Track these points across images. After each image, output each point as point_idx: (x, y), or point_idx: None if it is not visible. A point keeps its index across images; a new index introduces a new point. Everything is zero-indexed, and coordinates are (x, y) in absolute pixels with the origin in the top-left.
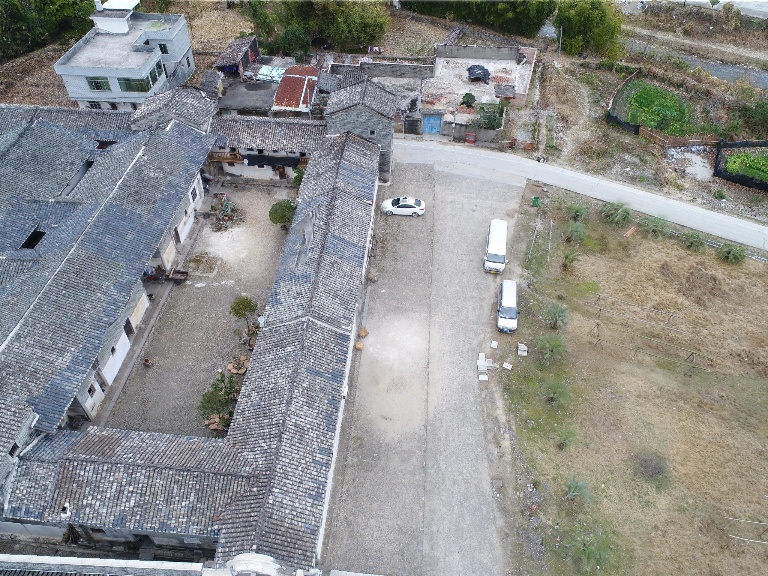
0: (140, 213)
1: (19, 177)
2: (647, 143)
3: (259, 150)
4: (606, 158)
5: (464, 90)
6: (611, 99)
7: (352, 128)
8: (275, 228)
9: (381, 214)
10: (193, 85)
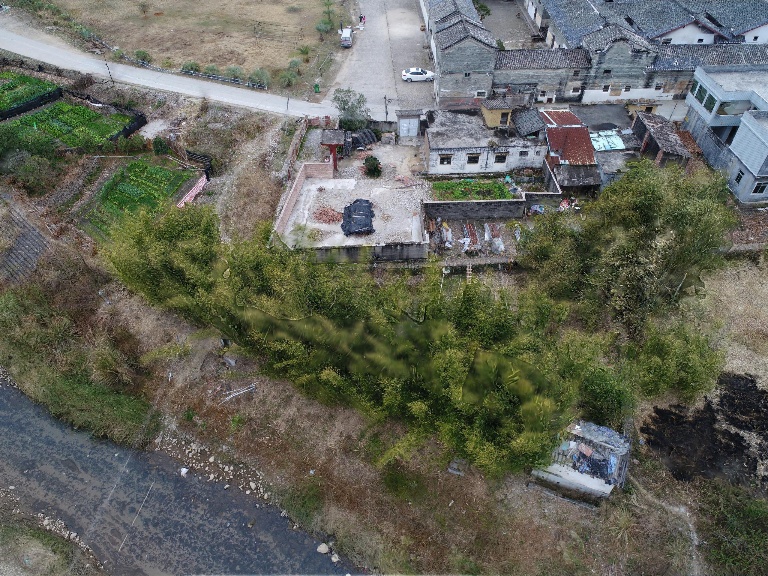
0: (563, 1)
1: (654, 4)
2: None
3: None
4: None
5: (377, 193)
6: None
7: None
8: None
9: None
10: (617, 38)
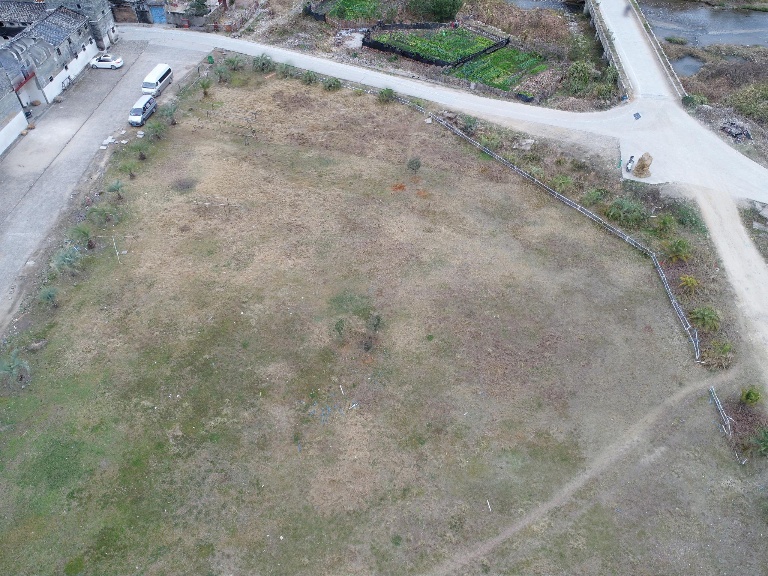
0: None
1: None
2: (327, 27)
3: (0, 24)
4: (286, 35)
5: None
6: (323, 2)
7: (63, 3)
8: (4, 76)
9: (89, 68)
10: None
